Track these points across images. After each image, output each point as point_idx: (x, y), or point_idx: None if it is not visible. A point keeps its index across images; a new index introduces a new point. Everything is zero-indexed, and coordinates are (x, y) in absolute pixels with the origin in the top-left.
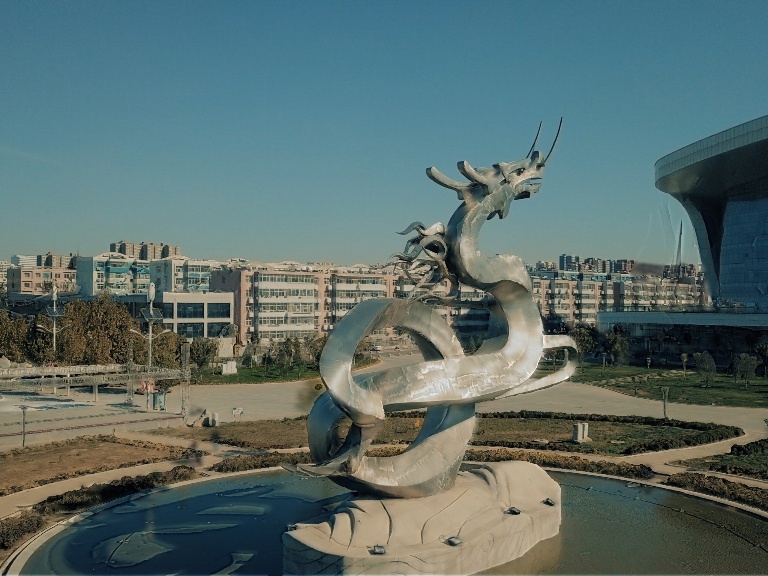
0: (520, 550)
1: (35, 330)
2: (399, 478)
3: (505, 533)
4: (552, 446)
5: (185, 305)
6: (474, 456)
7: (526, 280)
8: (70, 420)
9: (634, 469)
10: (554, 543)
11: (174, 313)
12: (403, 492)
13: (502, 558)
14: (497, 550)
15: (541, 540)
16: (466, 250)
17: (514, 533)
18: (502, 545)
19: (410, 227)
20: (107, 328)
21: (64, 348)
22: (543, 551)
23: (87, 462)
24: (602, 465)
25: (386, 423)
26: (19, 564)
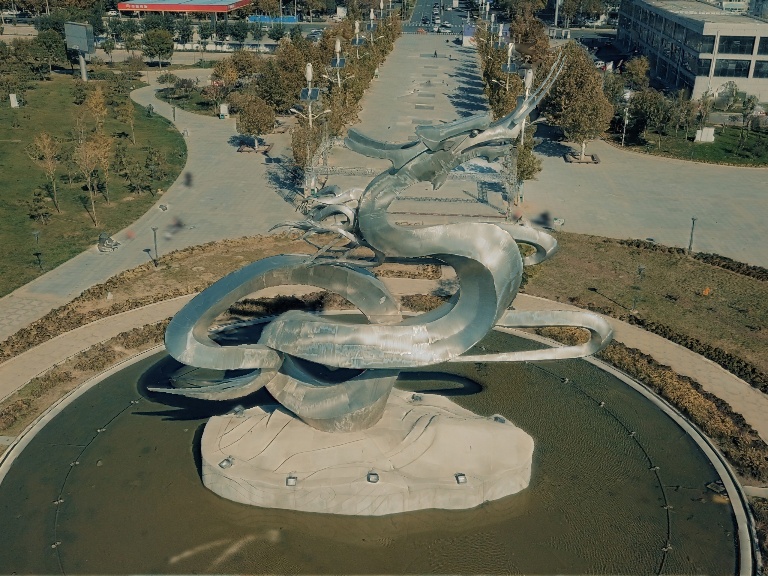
0: (376, 510)
1: (499, 81)
2: (303, 408)
3: (352, 492)
4: (766, 386)
5: (730, 38)
6: (632, 370)
7: (489, 252)
8: (413, 201)
9: (755, 467)
10: (457, 515)
11: (714, 47)
12: (305, 420)
13: (348, 510)
14: (341, 502)
15: (435, 507)
16: (370, 224)
17: (367, 495)
18: (347, 500)
19: (320, 192)
20: (564, 85)
21: (504, 107)
22: (438, 517)
23: (352, 258)
24: (739, 443)
25: (696, 275)
26: (133, 361)
